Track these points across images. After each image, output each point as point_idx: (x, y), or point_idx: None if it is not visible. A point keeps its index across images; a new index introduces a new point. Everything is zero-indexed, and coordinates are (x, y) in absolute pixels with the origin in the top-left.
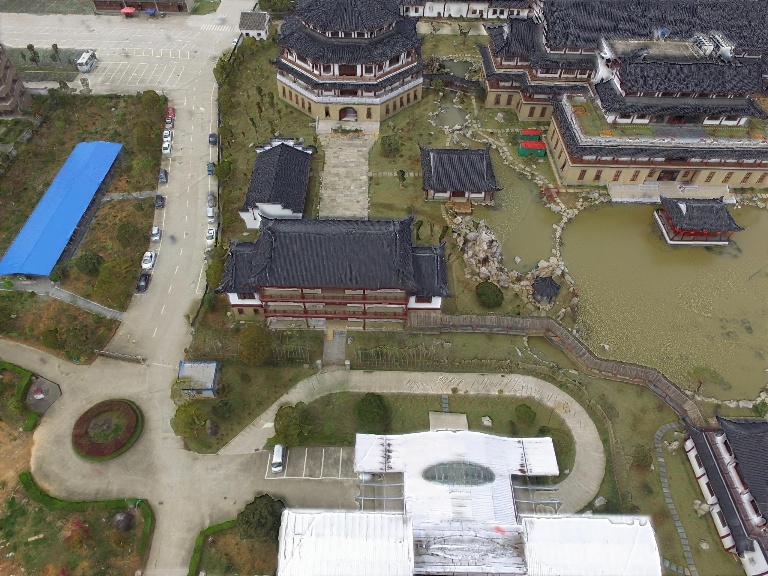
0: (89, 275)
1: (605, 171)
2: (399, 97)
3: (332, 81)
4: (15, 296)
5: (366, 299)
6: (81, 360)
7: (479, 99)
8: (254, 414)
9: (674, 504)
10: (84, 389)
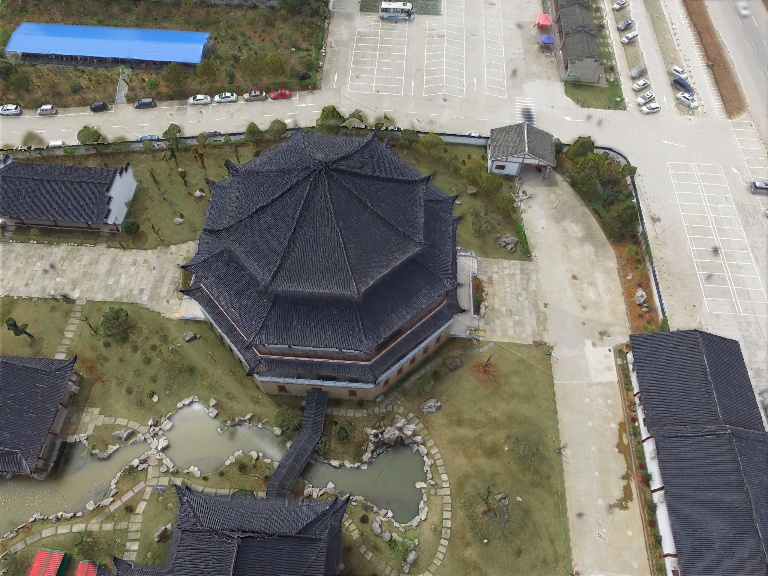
0: None
1: None
2: None
3: None
4: None
5: None
6: None
7: None
8: None
9: None
10: None
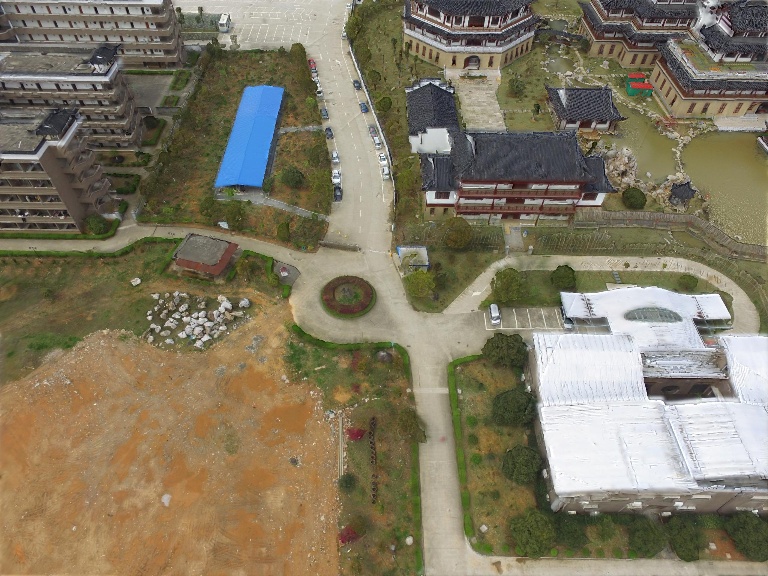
0: (293, 187)
1: (712, 104)
2: (516, 47)
3: (462, 32)
4: (235, 204)
5: (547, 194)
6: (309, 249)
7: (582, 50)
8: (463, 286)
9: None
10: (317, 270)
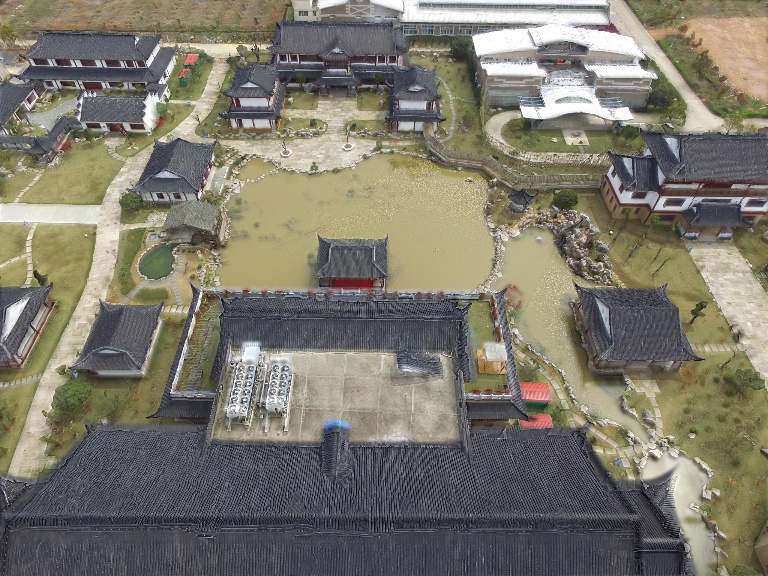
0: None
1: None
2: None
3: None
4: None
5: None
6: None
7: None
8: None
9: (452, 113)
10: None
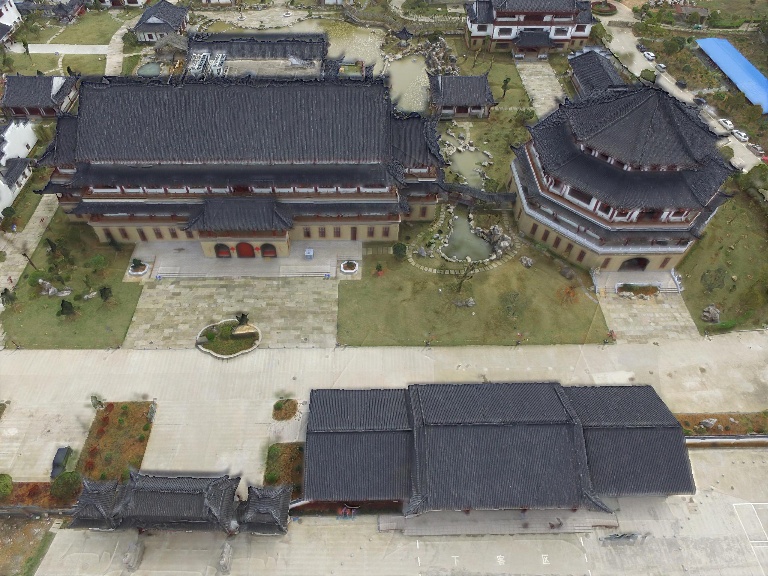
0: None
1: None
2: None
3: None
4: None
5: None
6: None
7: None
8: None
9: None
10: None
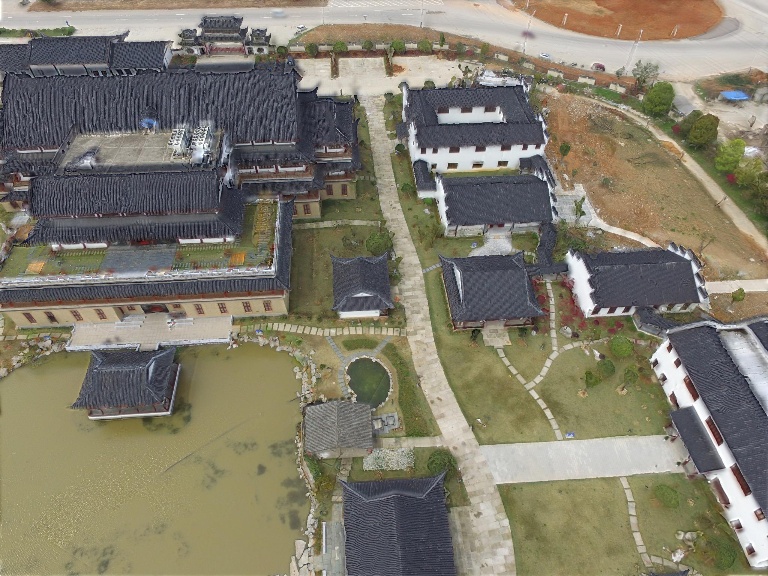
0: None
1: (54, 312)
2: None
3: None
4: None
5: None
6: None
7: None
8: None
9: None
10: None
